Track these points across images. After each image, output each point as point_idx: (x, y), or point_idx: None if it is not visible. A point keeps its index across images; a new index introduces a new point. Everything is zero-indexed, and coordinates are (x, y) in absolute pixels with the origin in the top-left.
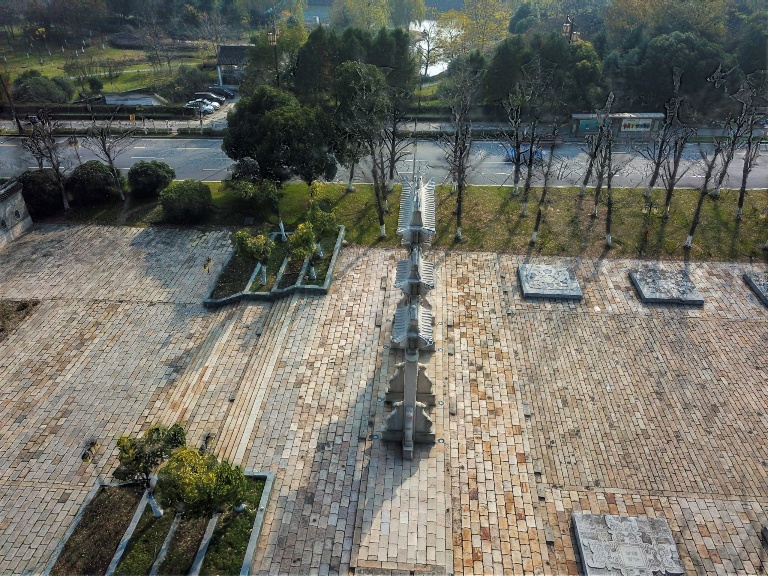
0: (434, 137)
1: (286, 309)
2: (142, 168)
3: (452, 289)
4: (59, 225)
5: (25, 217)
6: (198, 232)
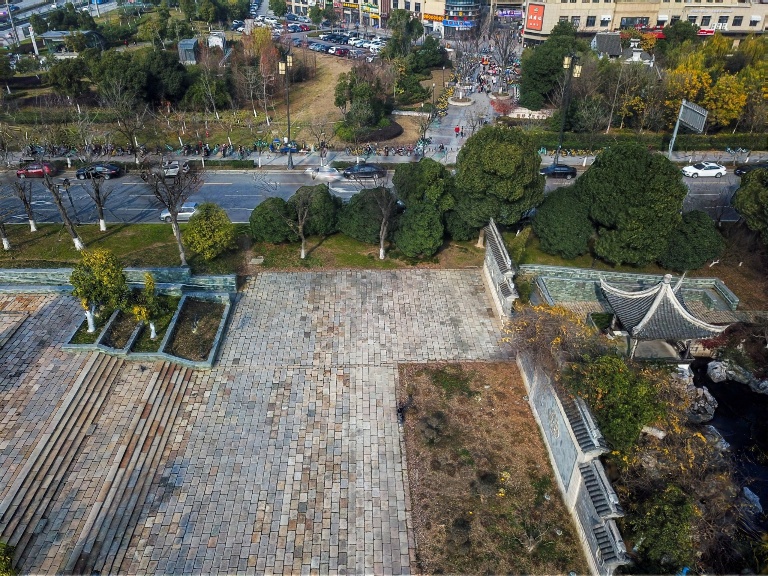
0: None
1: None
2: None
3: None
4: None
5: None
6: None
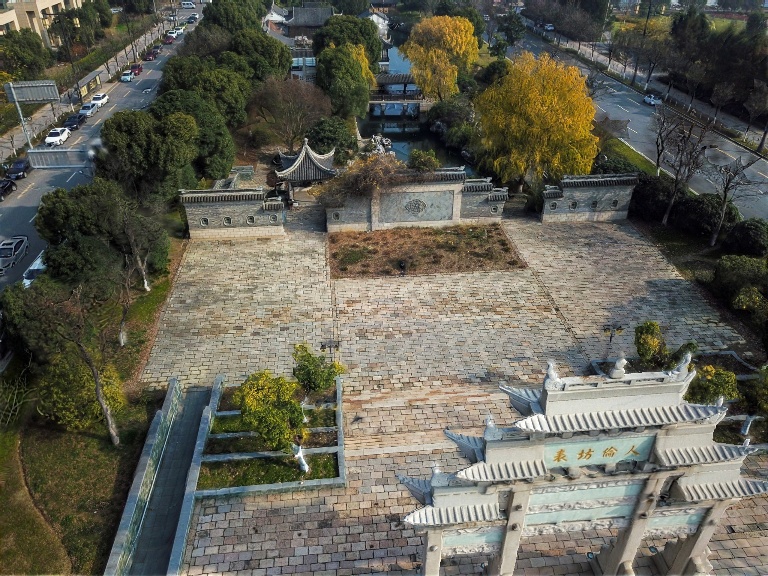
0: None
1: None
2: (750, 225)
3: None
4: (638, 232)
5: (622, 210)
6: (717, 316)
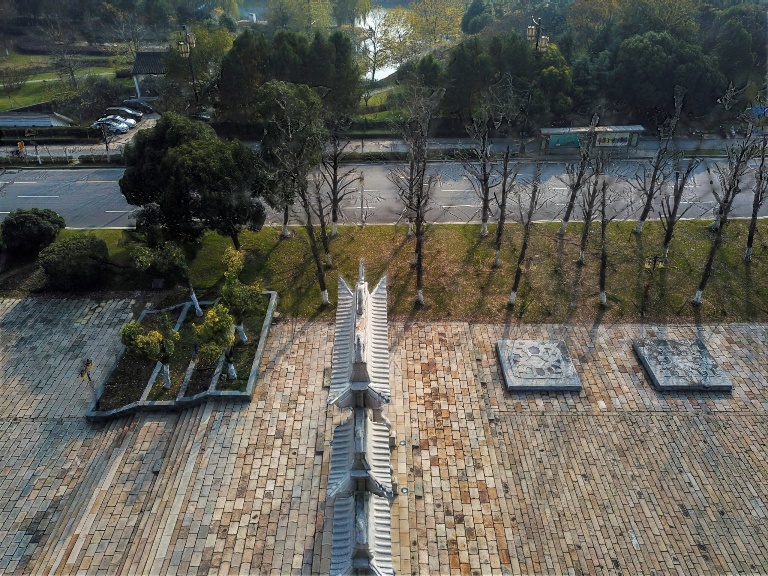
0: (385, 159)
1: (195, 429)
2: (18, 219)
3: (415, 383)
4: None
5: None
6: (91, 302)
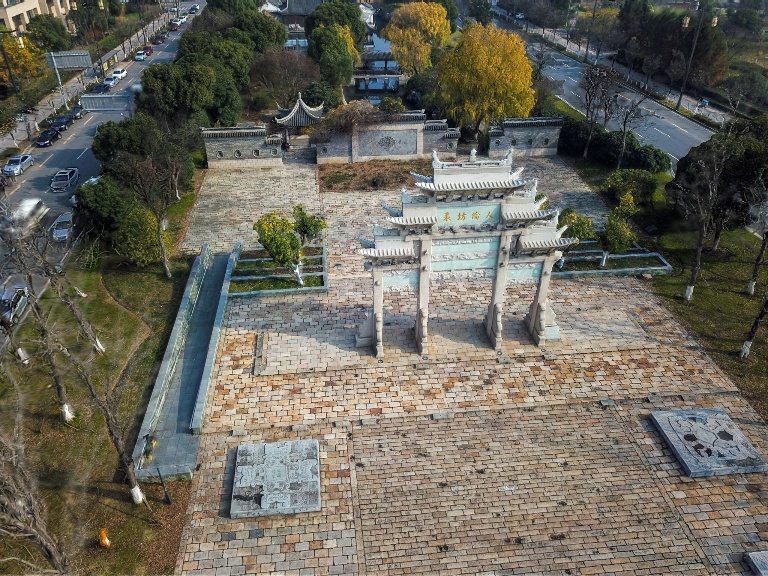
0: None
1: None
2: (642, 150)
3: (616, 356)
4: (564, 163)
5: (552, 147)
6: (610, 213)
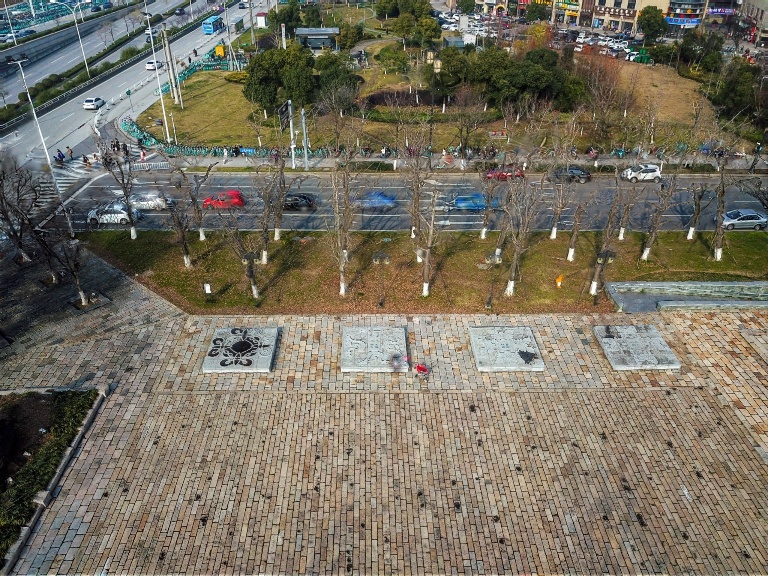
0: None
1: None
2: None
3: None
4: None
5: None
6: None
